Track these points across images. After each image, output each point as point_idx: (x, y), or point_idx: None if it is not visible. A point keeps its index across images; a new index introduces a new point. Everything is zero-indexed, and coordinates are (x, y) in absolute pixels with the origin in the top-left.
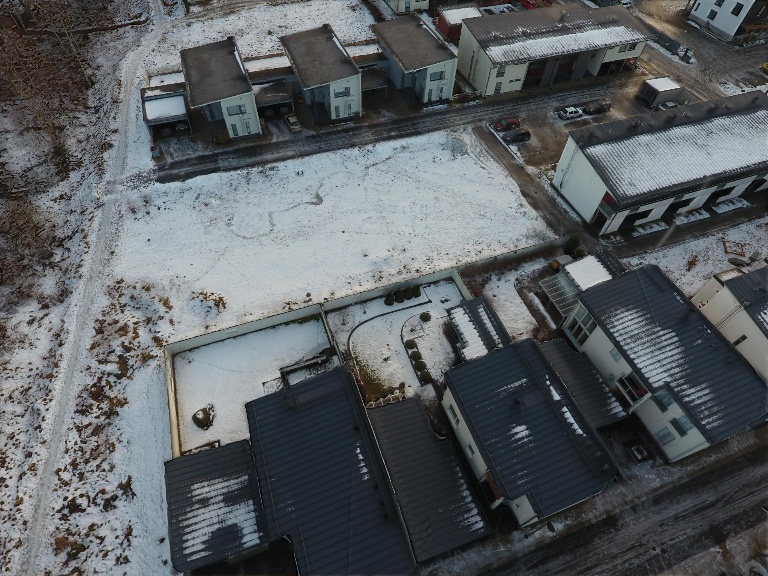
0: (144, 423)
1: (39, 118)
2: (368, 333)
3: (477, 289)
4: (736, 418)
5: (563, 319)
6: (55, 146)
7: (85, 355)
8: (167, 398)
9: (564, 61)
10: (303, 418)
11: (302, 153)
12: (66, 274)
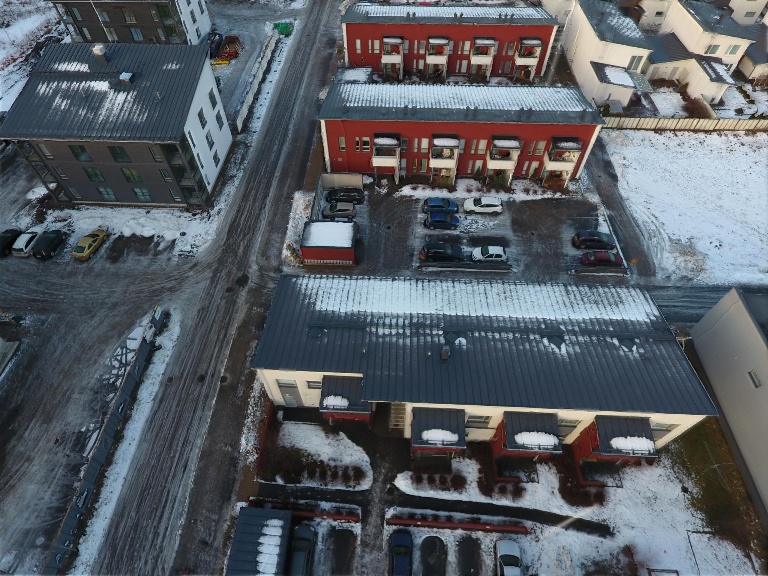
0: None
1: None
2: None
3: (693, 117)
4: None
5: None
6: None
7: None
8: None
9: None
10: None
11: None
12: None
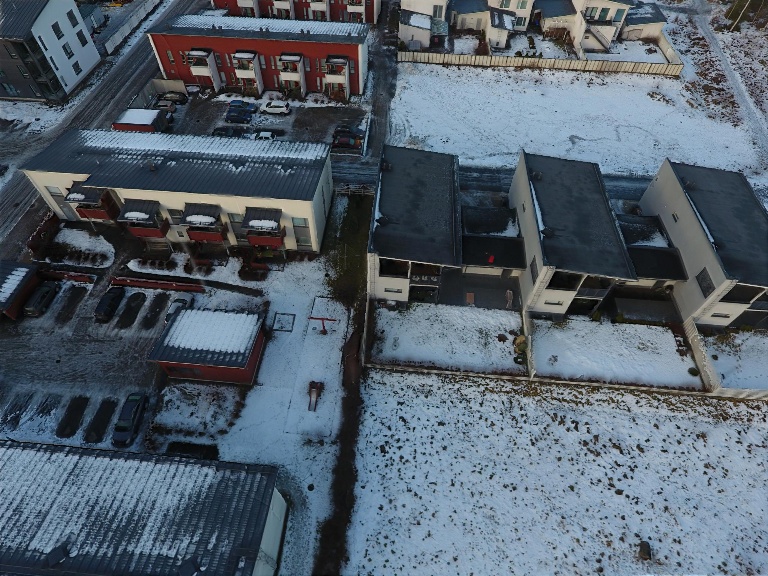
0: None
1: None
2: None
3: None
4: None
5: None
6: None
7: None
8: None
9: None
10: None
11: None
12: None
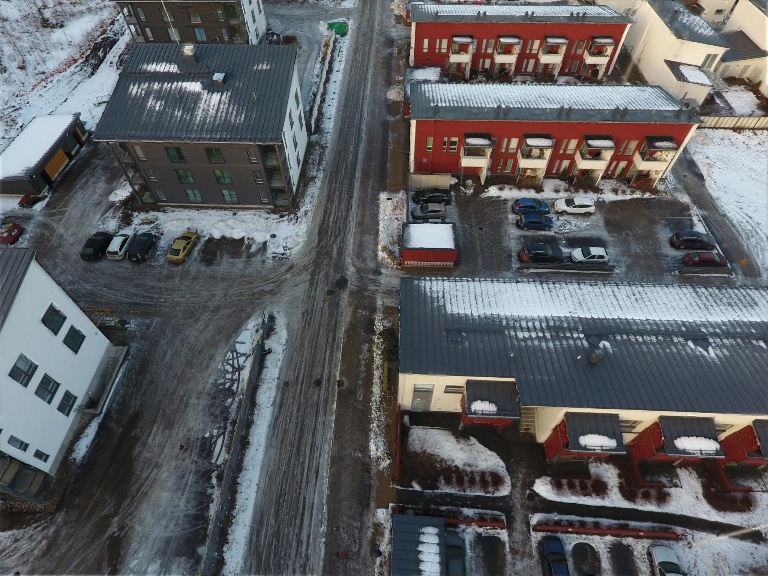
0: None
1: None
2: None
3: None
4: (667, 0)
5: None
6: None
7: None
8: None
9: None
10: None
11: None
12: None
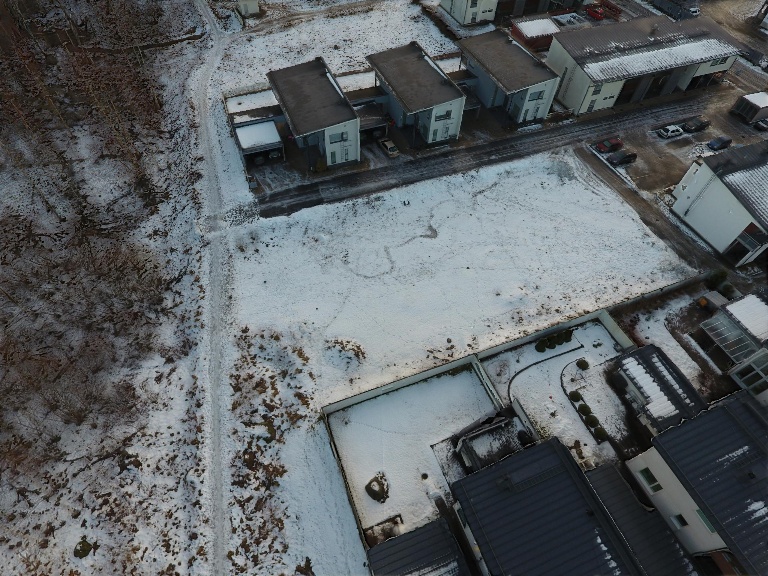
0: (311, 495)
1: (112, 145)
2: (526, 384)
3: (628, 331)
4: None
5: (734, 365)
6: (136, 176)
7: (228, 417)
8: (332, 466)
9: (655, 76)
10: (524, 501)
11: (405, 181)
12: (184, 322)
